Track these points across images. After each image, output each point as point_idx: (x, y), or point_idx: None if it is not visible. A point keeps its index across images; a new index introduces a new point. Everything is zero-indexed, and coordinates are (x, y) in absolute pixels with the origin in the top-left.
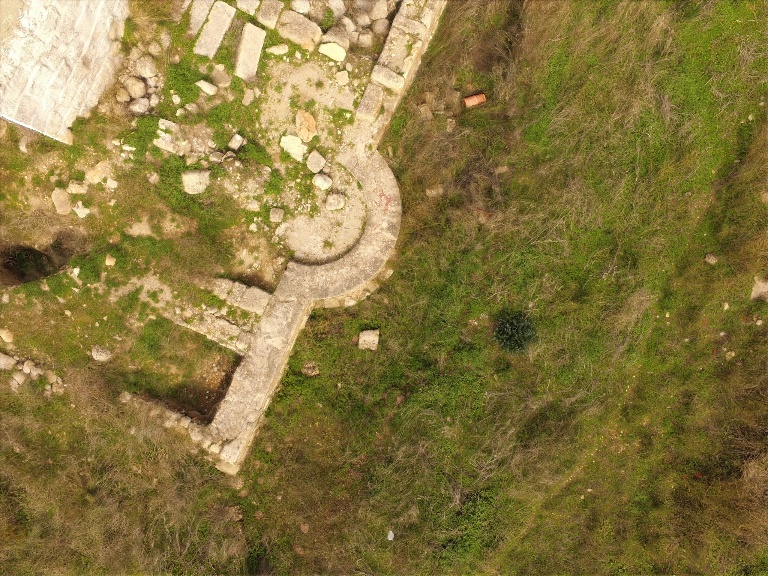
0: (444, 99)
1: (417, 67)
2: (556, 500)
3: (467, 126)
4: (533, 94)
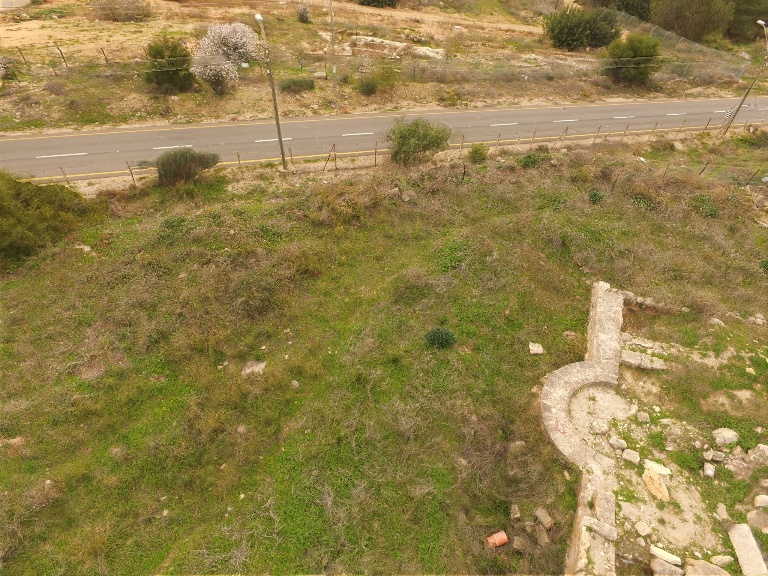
0: (529, 536)
1: (566, 572)
2: (402, 268)
3: (500, 508)
4: (452, 519)
